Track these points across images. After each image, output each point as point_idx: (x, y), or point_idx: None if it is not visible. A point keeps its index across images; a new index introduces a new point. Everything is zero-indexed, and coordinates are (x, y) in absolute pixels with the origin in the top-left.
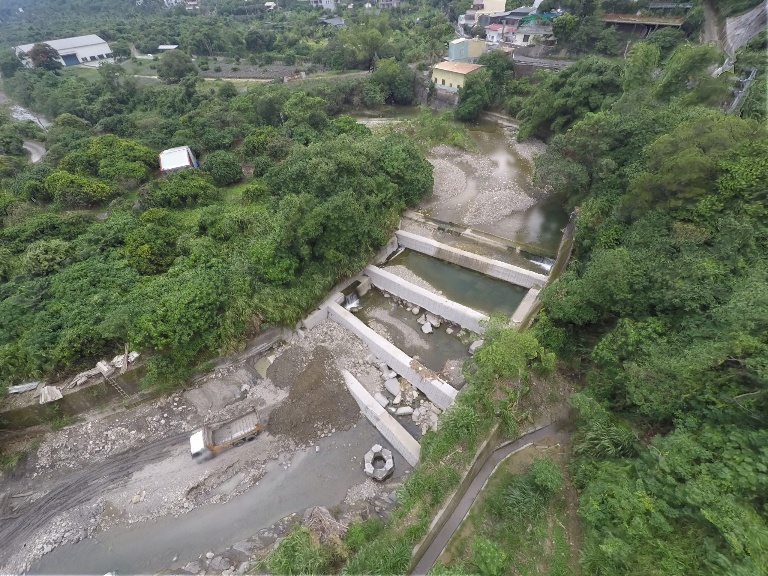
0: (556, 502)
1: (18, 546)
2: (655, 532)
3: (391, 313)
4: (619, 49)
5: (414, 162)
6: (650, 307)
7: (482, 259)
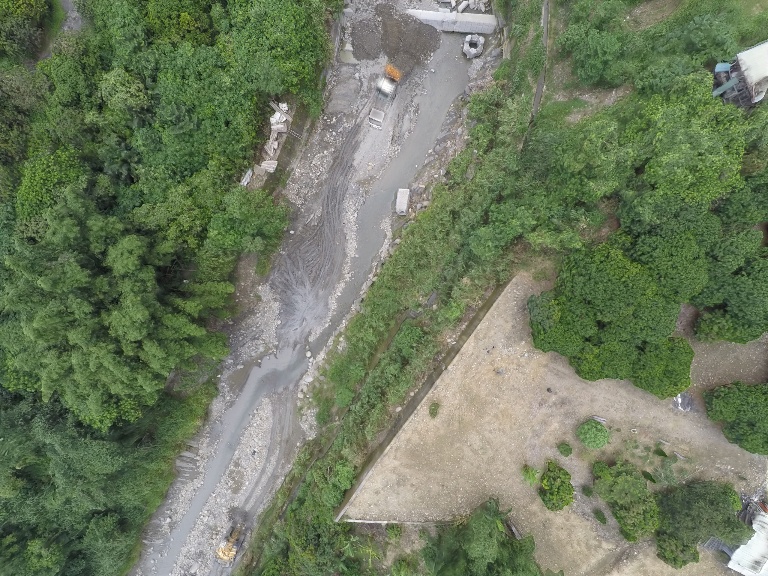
0: None
1: (341, 226)
2: None
3: None
4: None
5: None
6: None
7: None
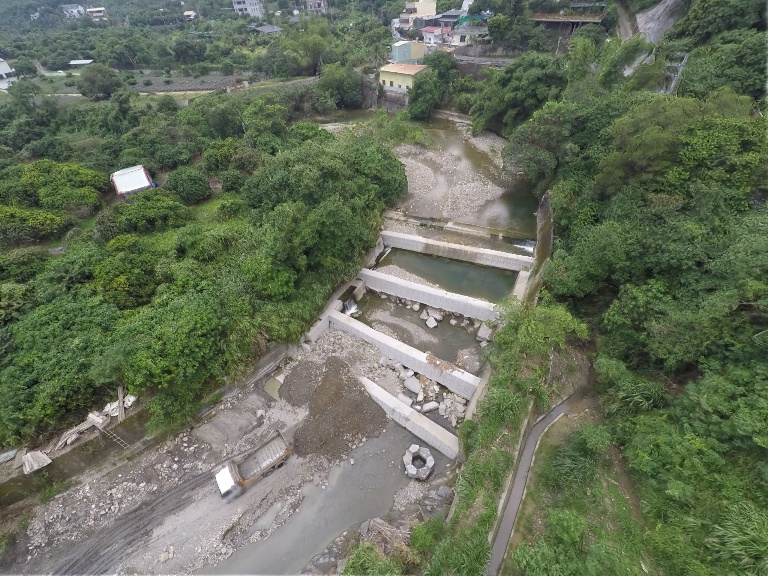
0: (603, 463)
1: None
2: (708, 468)
3: (392, 313)
4: (549, 45)
5: (387, 162)
6: (646, 271)
7: (470, 249)
